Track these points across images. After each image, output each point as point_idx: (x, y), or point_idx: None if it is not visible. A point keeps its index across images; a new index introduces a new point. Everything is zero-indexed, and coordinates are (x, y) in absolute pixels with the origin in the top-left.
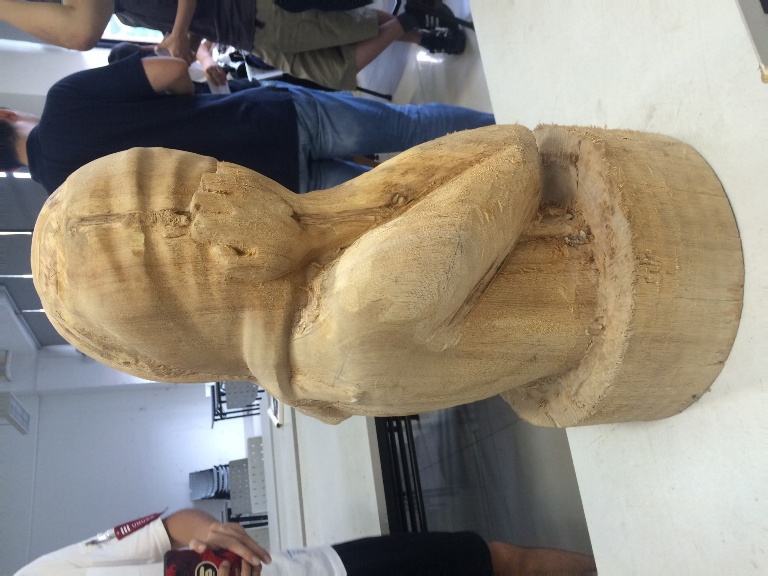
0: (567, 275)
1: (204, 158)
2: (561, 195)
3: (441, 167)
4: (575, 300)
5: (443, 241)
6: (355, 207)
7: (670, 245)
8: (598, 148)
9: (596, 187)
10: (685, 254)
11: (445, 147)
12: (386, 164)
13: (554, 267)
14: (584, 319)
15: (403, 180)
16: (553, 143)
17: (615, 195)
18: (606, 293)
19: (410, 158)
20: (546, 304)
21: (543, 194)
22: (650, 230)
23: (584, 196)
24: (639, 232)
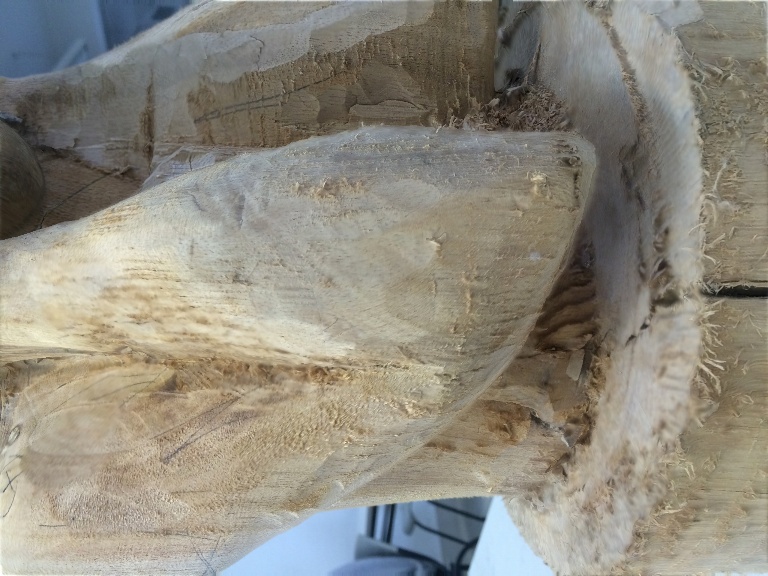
0: (503, 460)
1: None
2: (606, 285)
3: (227, 347)
4: (501, 483)
5: (168, 574)
6: (34, 344)
7: (706, 565)
8: (695, 398)
9: (642, 419)
10: (731, 567)
11: (245, 301)
12: (101, 261)
13: (482, 449)
14: (508, 493)
15: (136, 334)
16: (670, 158)
17: (649, 496)
18: (558, 504)
19: (154, 287)
20: (442, 481)
21: (594, 207)
22: (676, 558)
23: (622, 380)
24: (644, 562)
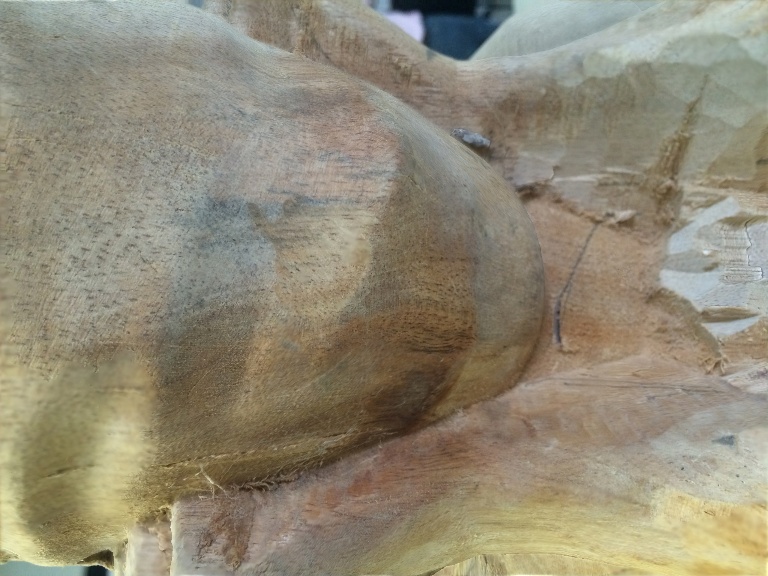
0: None
1: (120, 392)
2: None
3: None
4: None
5: None
6: None
7: None
8: None
9: None
10: None
11: None
12: None
13: None
14: None
15: None
16: None
17: None
18: None
19: None
20: None
21: None
22: None
23: None
24: None
